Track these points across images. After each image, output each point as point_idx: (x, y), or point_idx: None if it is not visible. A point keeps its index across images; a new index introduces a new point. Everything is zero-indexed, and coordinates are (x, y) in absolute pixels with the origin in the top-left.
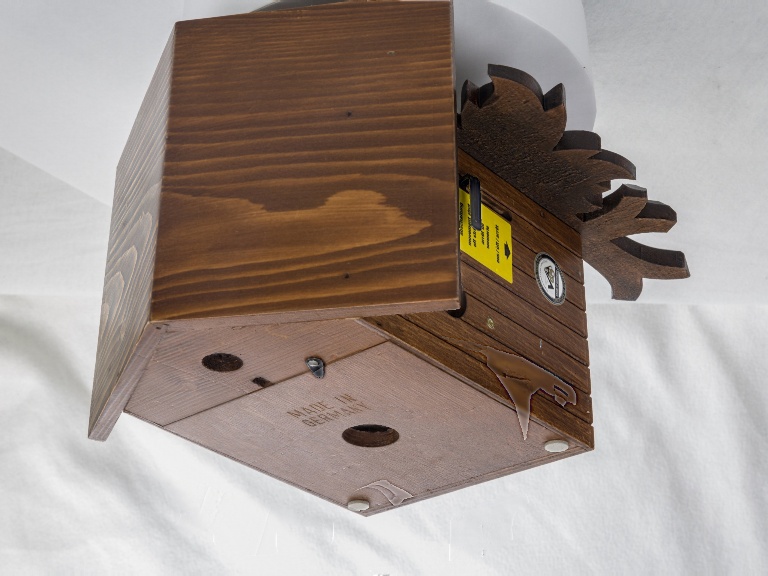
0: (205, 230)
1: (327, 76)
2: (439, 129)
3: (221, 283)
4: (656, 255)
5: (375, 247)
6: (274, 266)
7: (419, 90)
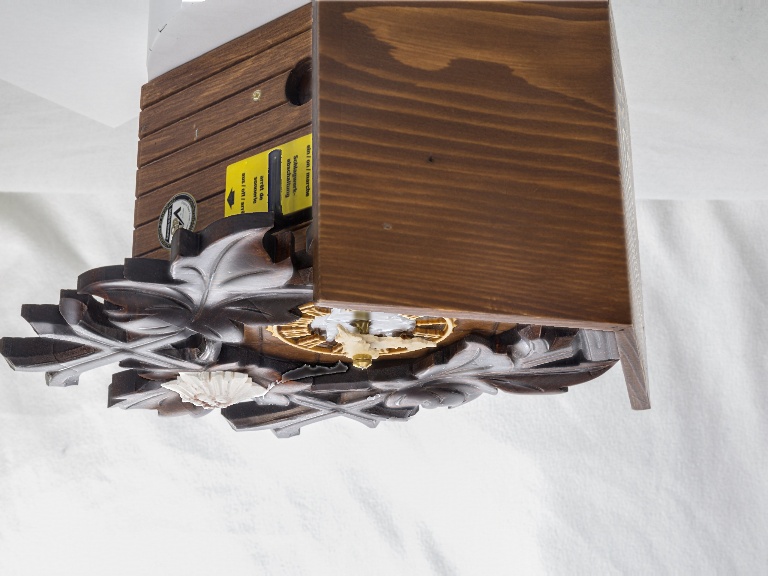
0: (567, 60)
1: (457, 212)
2: (335, 118)
3: (545, 1)
4: (35, 348)
5: (399, 3)
6: (496, 6)
7: (356, 171)
